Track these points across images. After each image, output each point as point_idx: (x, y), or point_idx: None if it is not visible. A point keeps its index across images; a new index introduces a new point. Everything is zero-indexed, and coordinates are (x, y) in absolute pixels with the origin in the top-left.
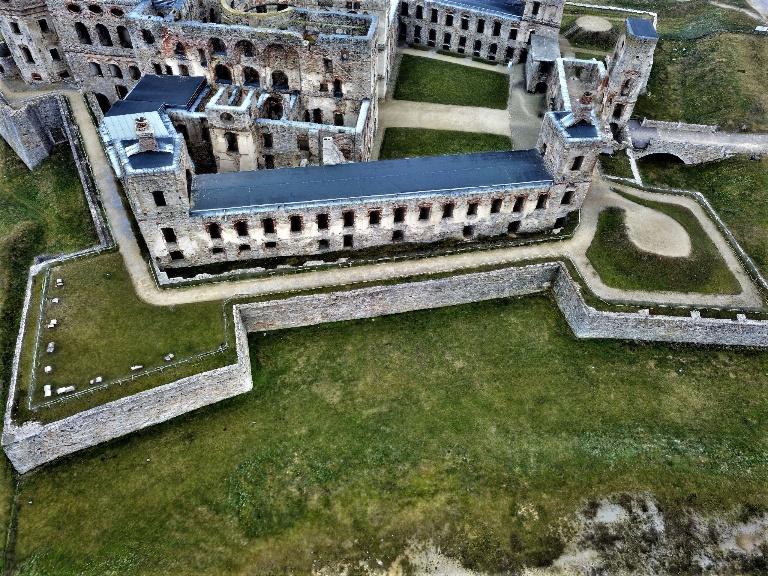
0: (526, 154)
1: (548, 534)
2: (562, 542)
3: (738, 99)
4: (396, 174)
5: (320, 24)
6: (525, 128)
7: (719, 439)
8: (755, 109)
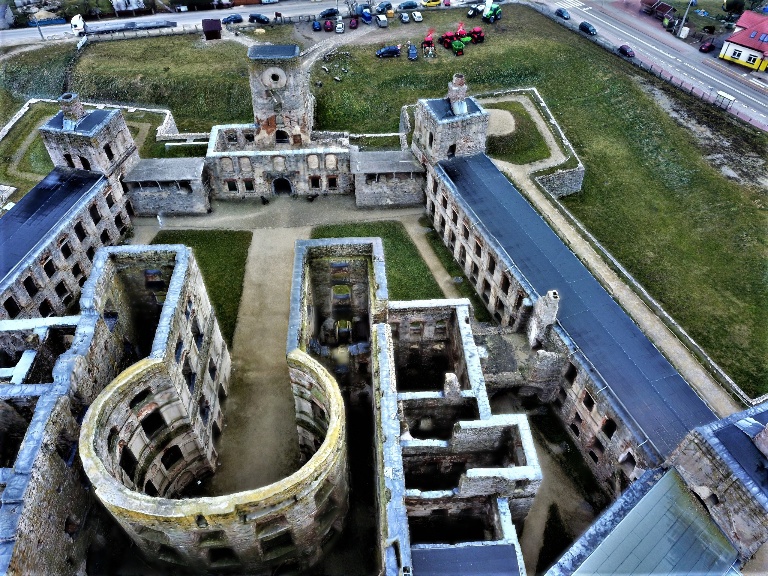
0: (452, 167)
1: (765, 196)
2: (765, 190)
3: (221, 78)
4: (541, 253)
5: (306, 323)
6: (293, 215)
7: (631, 135)
8: (240, 72)
